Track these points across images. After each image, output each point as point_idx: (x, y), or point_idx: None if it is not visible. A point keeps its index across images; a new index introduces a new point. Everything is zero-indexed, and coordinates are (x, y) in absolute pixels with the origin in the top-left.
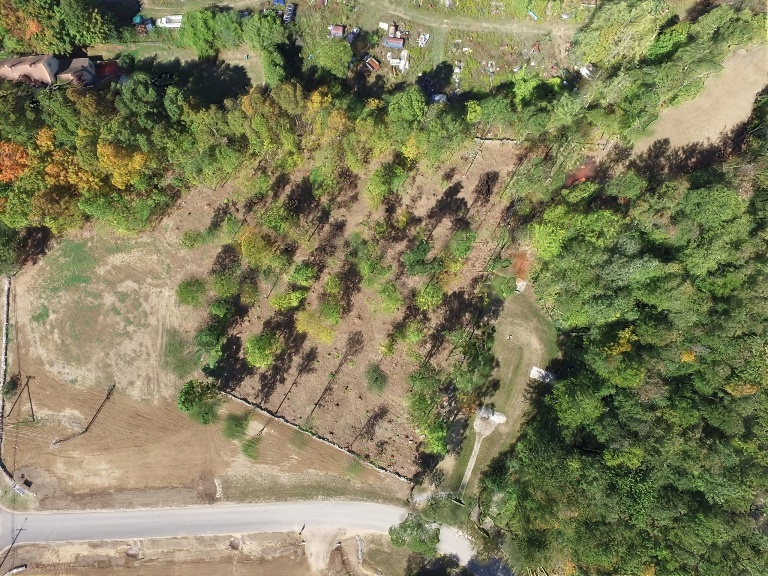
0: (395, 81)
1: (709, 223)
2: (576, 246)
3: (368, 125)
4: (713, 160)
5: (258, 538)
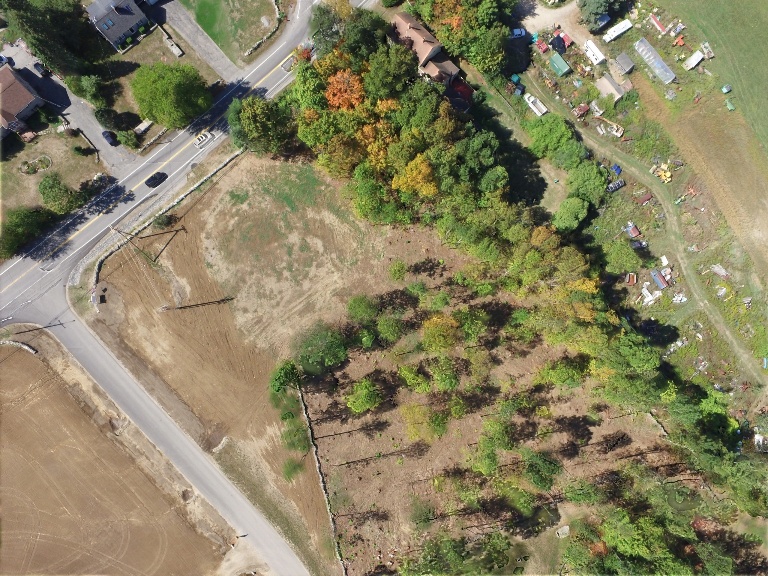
0: (632, 305)
1: None
2: (646, 571)
3: (602, 338)
4: None
5: (207, 508)
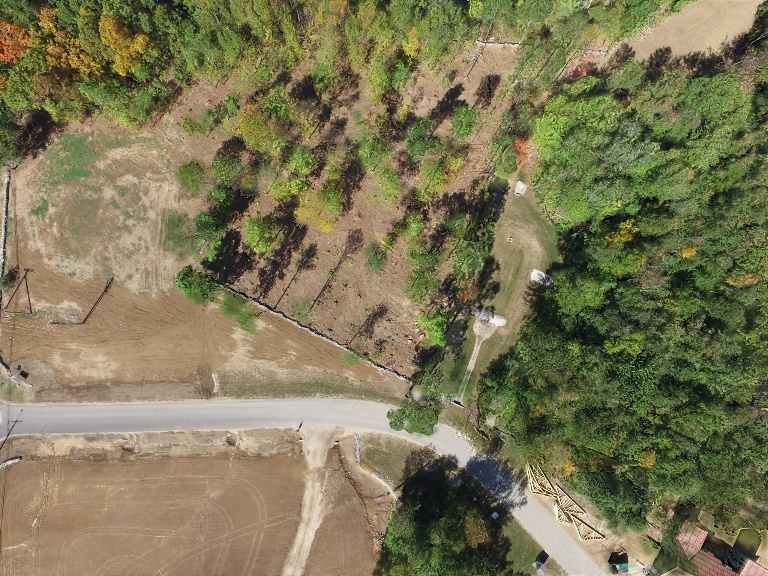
0: None
1: (711, 114)
2: (577, 131)
3: (370, 8)
4: None
5: (255, 434)
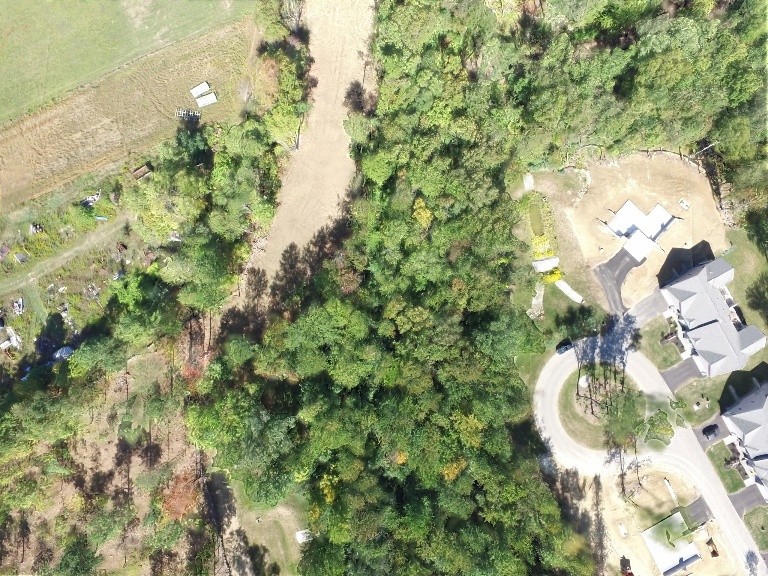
0: (16, 361)
1: (331, 339)
2: None
3: None
4: (347, 233)
5: None
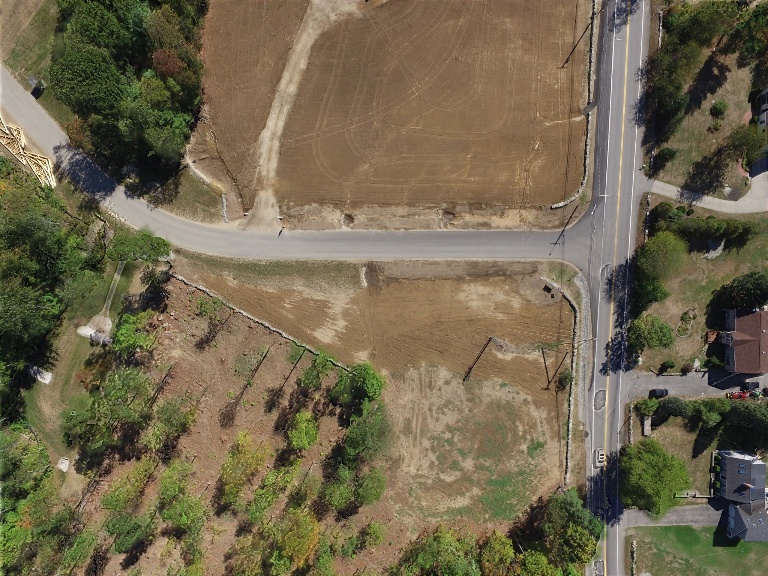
0: None
1: None
2: None
3: None
4: None
5: (325, 225)
